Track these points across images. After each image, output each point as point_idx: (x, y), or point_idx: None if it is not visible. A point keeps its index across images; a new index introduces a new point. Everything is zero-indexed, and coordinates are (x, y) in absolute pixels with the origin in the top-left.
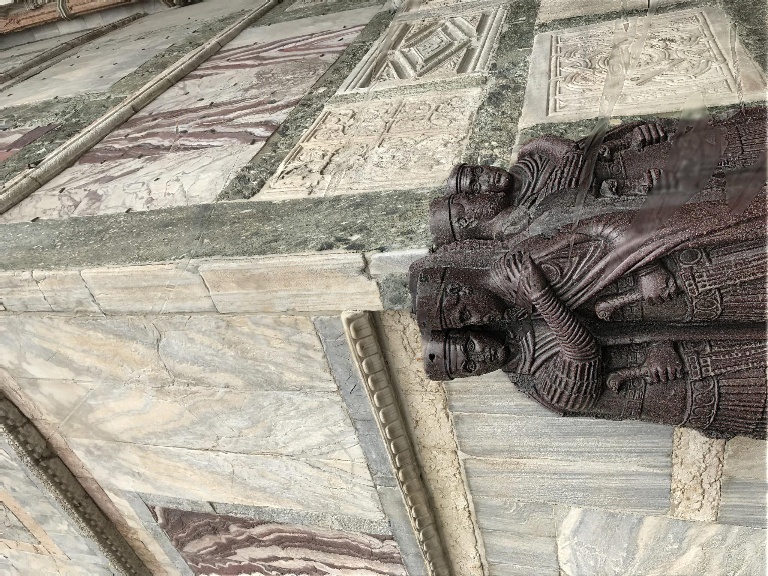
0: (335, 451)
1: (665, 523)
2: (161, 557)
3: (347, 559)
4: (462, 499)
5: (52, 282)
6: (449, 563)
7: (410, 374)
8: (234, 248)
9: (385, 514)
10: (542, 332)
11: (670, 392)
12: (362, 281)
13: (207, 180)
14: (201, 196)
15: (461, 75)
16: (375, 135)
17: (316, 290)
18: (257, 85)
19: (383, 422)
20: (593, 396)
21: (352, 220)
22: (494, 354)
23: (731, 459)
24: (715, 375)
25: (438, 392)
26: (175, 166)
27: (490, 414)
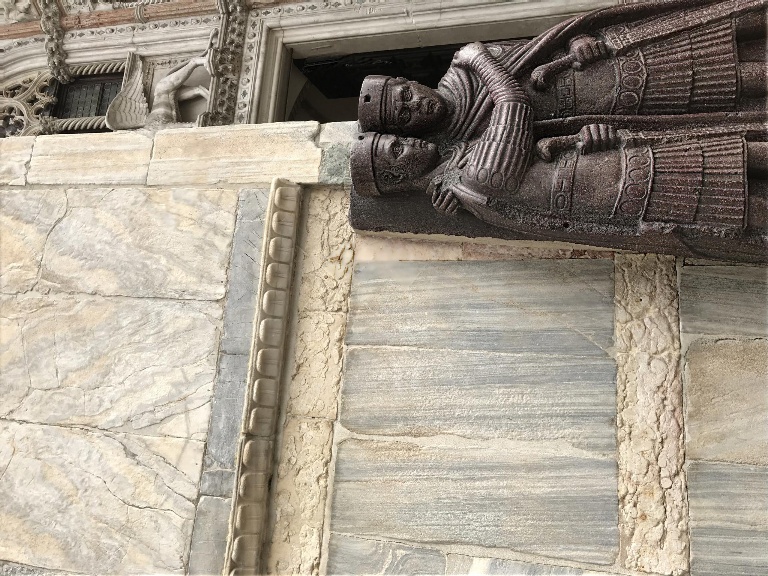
0: (172, 417)
1: None
2: None
3: None
4: (314, 541)
5: (1, 143)
6: None
7: (316, 282)
8: None
9: (186, 575)
10: None
11: (603, 160)
12: (308, 147)
13: None
14: None
15: None
16: None
17: (259, 157)
18: None
19: (260, 337)
20: (522, 152)
21: None
22: (425, 143)
23: (693, 422)
24: (648, 140)
25: (340, 312)
26: None
27: (393, 348)
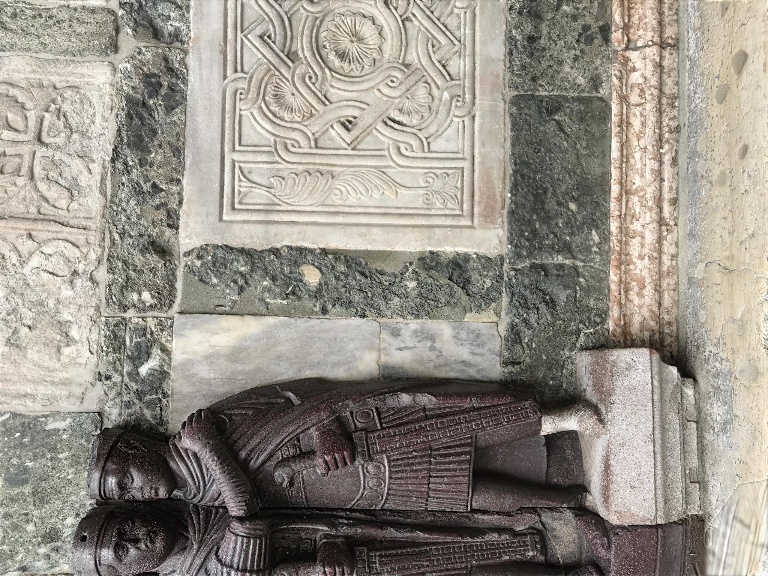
0: None
1: None
2: None
3: None
4: None
5: None
6: None
7: None
8: None
9: None
10: None
11: None
12: None
13: None
14: None
15: None
16: None
17: None
18: None
19: None
20: None
21: None
22: None
23: None
24: None
25: None
26: None
27: None
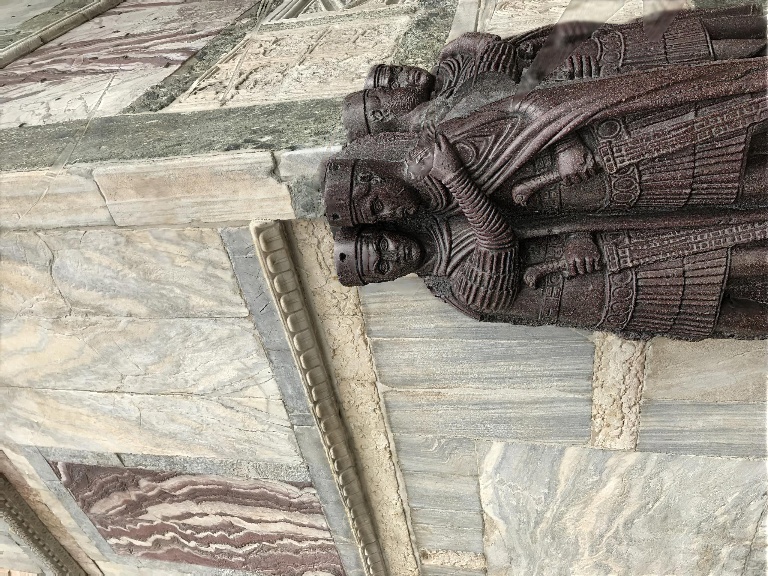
0: (249, 387)
1: (586, 454)
2: (67, 521)
3: (265, 512)
4: (383, 438)
5: None
6: (371, 511)
7: (326, 295)
8: (133, 152)
9: (303, 458)
10: (459, 229)
11: (588, 287)
12: (271, 184)
13: (113, 97)
14: (104, 110)
15: (390, 6)
16: (296, 55)
17: (222, 196)
18: (178, 20)
19: (297, 349)
20: (510, 293)
21: (264, 125)
22: (408, 253)
23: (650, 379)
24: (633, 266)
25: (355, 315)
26: (80, 87)
27: (410, 339)
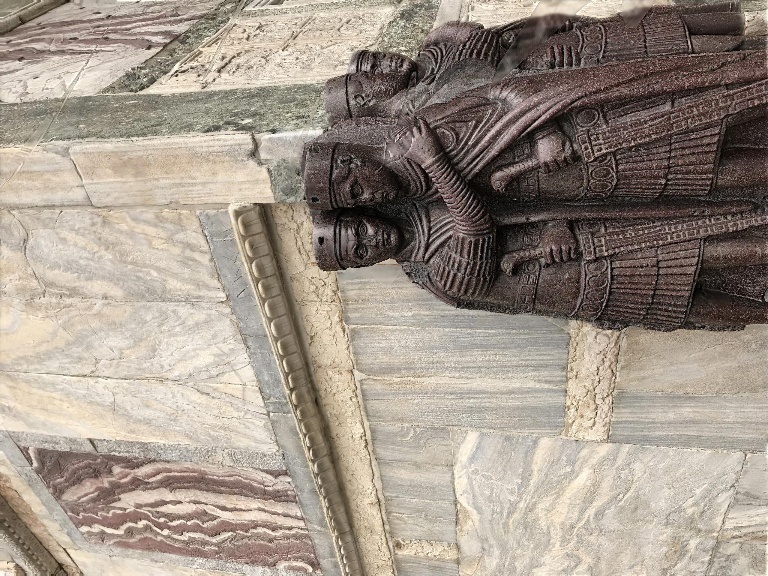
0: (225, 373)
1: (559, 445)
2: (38, 508)
3: (239, 500)
4: (358, 426)
5: None
6: (345, 500)
7: (304, 281)
8: (111, 131)
9: (279, 446)
10: (438, 215)
11: (564, 275)
12: (251, 167)
13: (92, 78)
14: (83, 90)
15: None
16: (280, 41)
17: (201, 178)
18: (161, 3)
19: (275, 335)
20: (487, 279)
21: (245, 108)
22: (387, 238)
23: (623, 370)
24: (608, 255)
25: (334, 302)
26: (59, 67)
27: (387, 326)
